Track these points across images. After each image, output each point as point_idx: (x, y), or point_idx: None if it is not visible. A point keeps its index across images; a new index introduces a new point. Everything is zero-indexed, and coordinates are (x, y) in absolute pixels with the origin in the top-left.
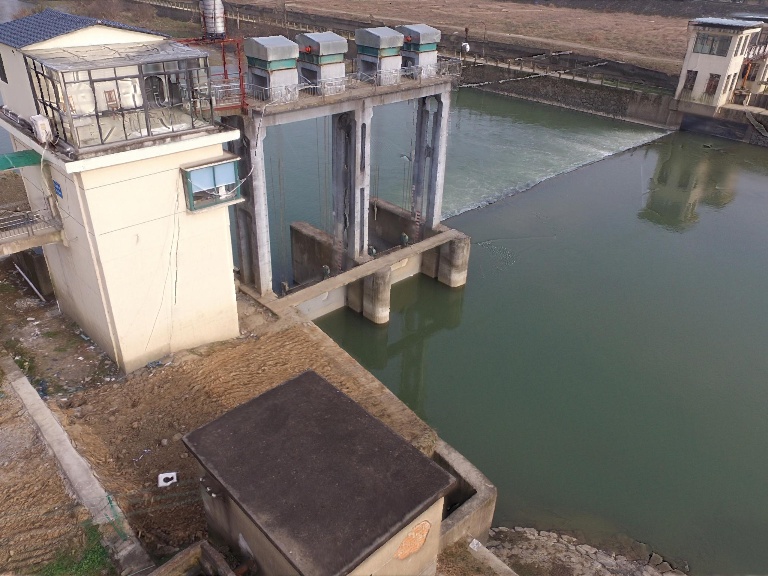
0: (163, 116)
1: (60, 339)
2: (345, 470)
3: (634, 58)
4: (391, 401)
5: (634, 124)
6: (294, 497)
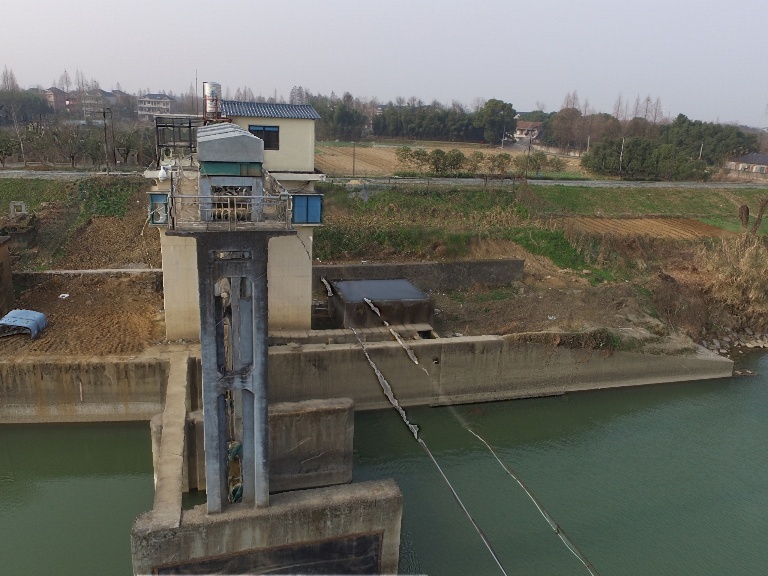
0: None
1: None
2: None
3: None
4: None
5: None
6: None
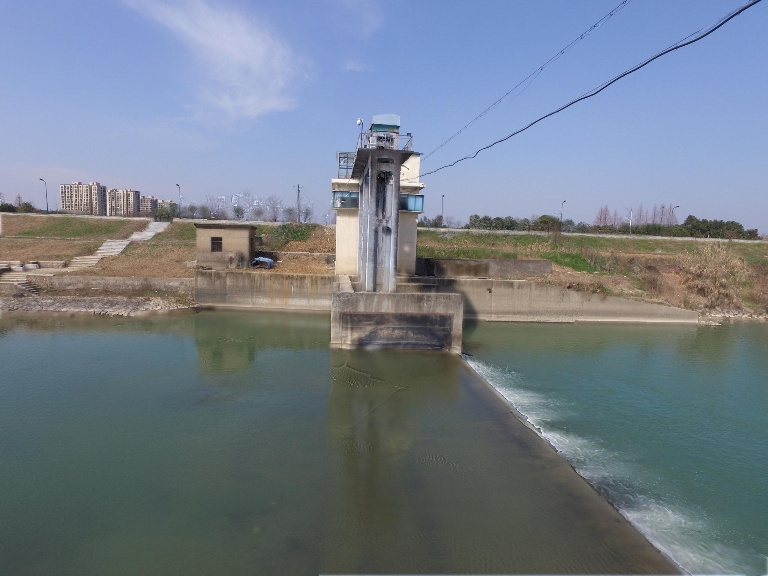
0: None
1: None
2: None
3: None
4: None
5: None
6: None
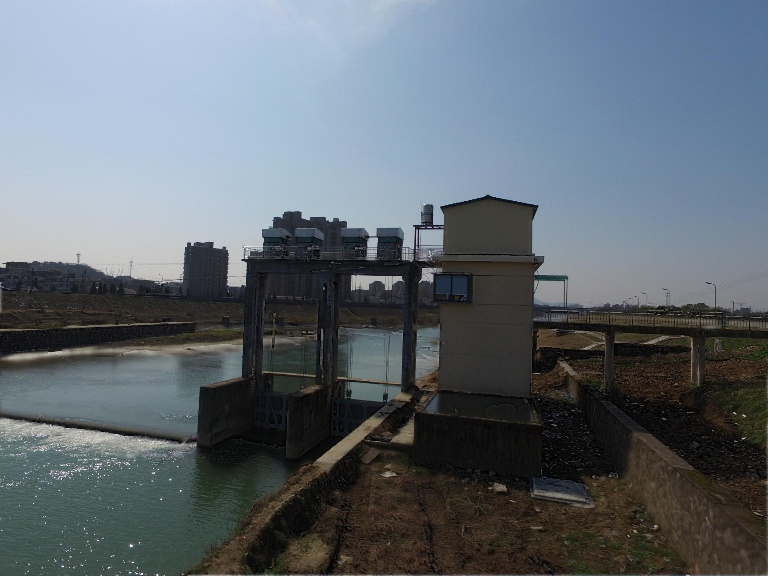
0: None
1: (543, 408)
2: None
3: None
4: None
5: None
6: None
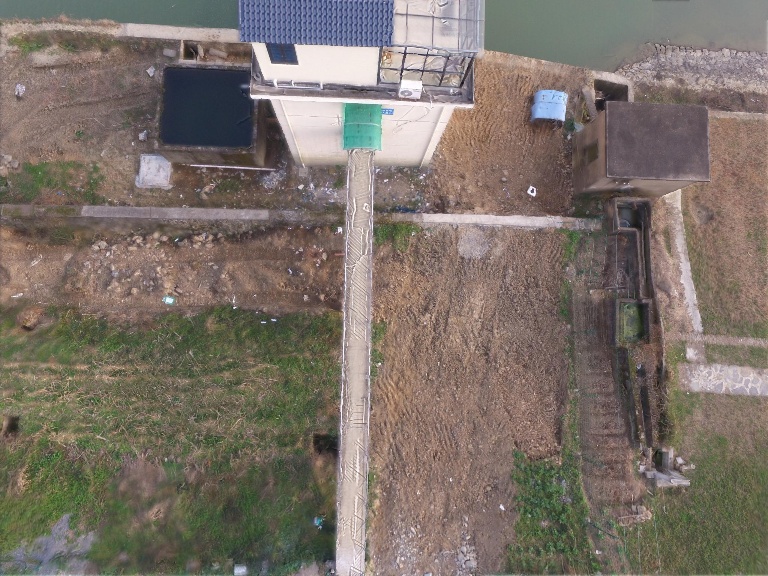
0: None
1: None
2: (674, 136)
3: None
4: (552, 67)
5: None
6: (671, 161)
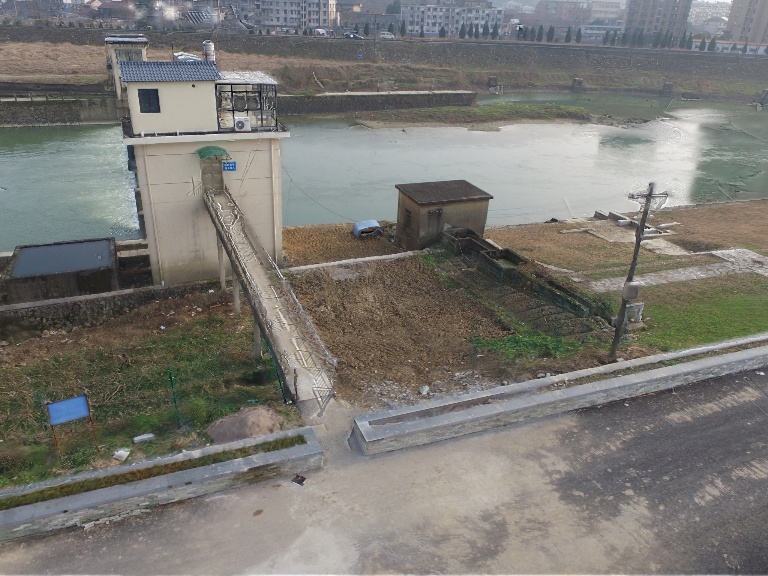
0: (226, 115)
1: None
2: None
3: (13, 78)
4: None
5: (92, 126)
6: None
